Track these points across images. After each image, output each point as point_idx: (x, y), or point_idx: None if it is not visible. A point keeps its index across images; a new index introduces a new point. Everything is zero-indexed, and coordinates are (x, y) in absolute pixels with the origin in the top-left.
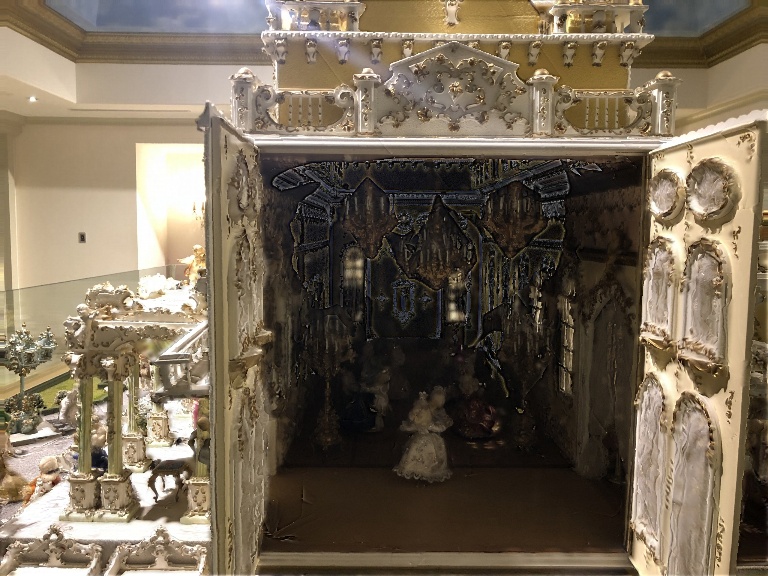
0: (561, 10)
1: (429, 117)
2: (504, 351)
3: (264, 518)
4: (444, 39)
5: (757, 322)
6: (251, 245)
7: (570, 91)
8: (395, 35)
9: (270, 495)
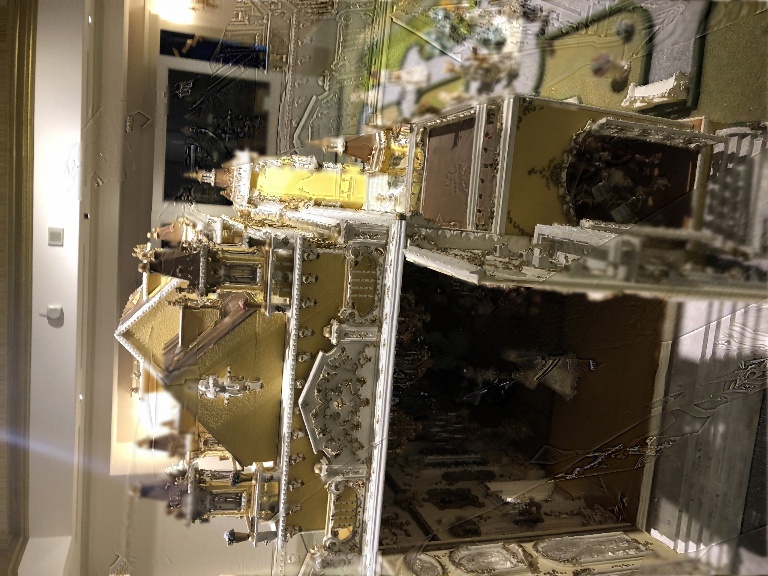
0: (271, 310)
1: (358, 423)
2: (474, 290)
3: (602, 508)
4: (292, 408)
5: (532, 170)
6: (470, 575)
7: (345, 312)
8: (287, 447)
9: (577, 492)
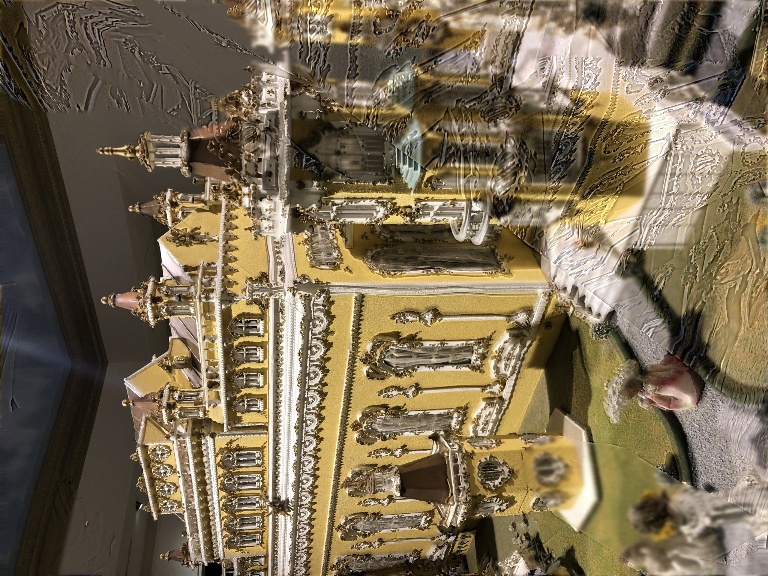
0: None
1: None
2: None
3: None
4: None
5: None
6: None
7: None
8: None
9: None
